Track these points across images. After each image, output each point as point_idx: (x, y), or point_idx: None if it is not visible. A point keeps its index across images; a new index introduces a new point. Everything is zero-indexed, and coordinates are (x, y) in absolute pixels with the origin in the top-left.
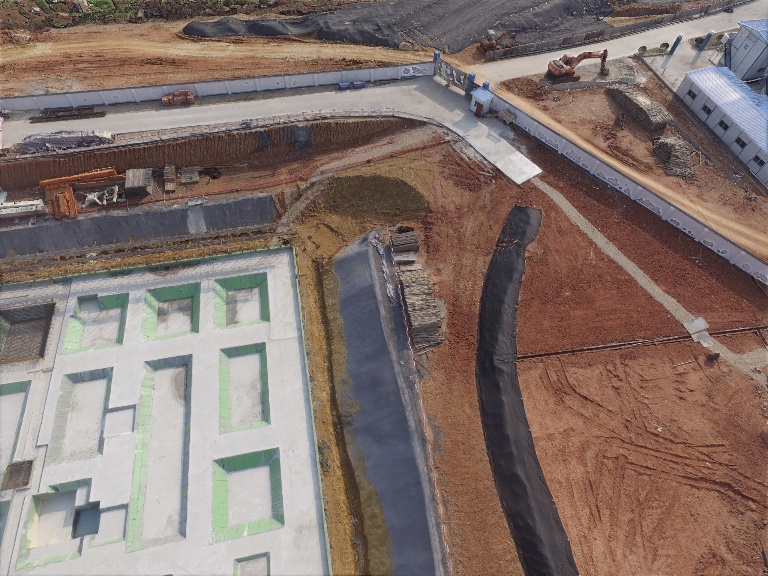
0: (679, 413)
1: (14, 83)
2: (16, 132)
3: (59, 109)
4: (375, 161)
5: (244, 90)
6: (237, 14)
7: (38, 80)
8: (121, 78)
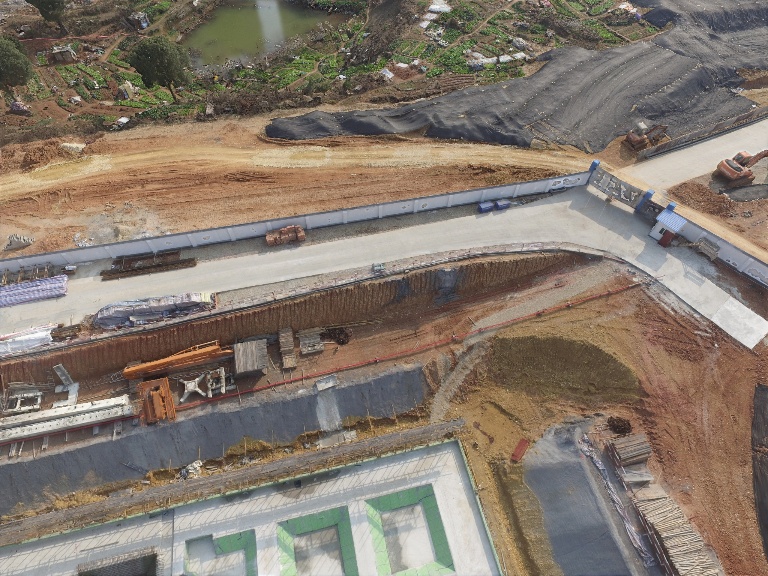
0: None
1: (72, 217)
2: (86, 296)
3: (136, 257)
4: (547, 314)
5: (362, 218)
6: (322, 105)
7: (102, 212)
8: (205, 205)
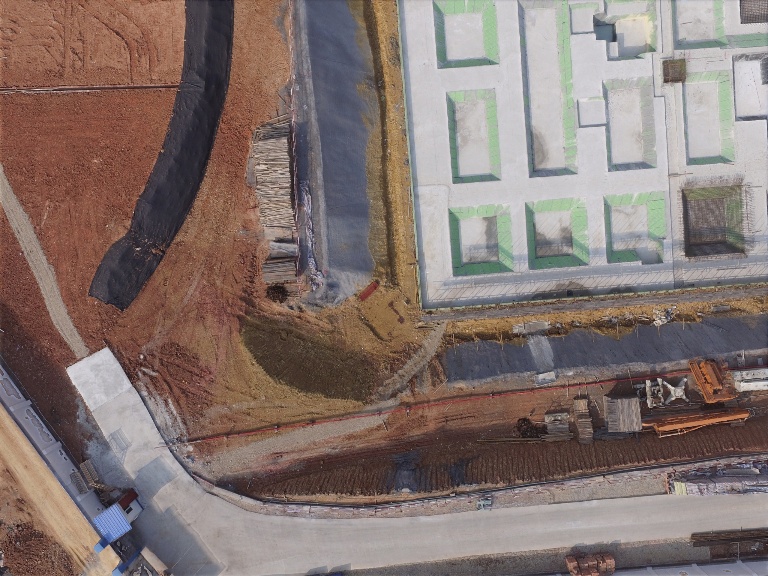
0: (24, 7)
1: None
2: None
3: (760, 557)
4: (303, 421)
5: None
6: None
7: None
8: None
